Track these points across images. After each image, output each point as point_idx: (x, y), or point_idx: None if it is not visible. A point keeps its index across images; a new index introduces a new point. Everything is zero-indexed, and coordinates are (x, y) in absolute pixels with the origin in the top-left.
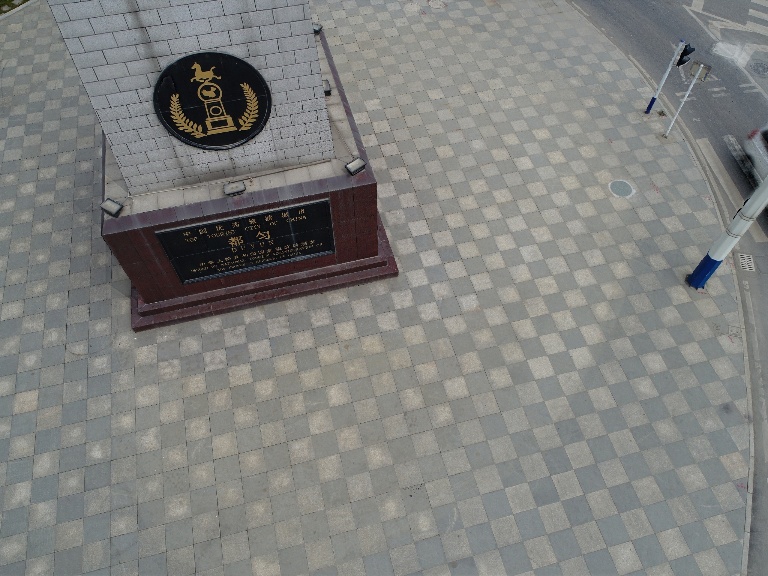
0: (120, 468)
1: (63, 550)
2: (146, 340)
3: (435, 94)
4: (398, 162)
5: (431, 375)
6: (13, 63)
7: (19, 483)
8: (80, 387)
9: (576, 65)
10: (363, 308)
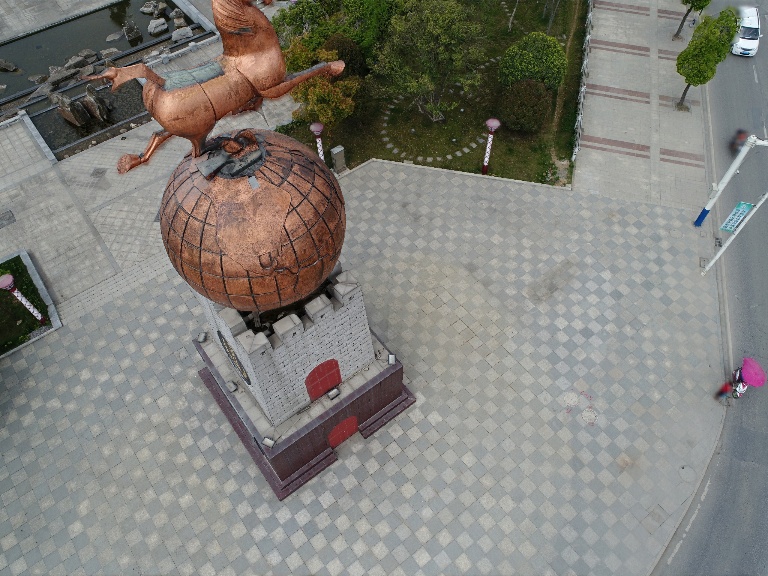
0: (123, 412)
1: (81, 411)
2: (196, 382)
3: (469, 459)
4: (383, 460)
5: (212, 552)
6: (370, 196)
7: (108, 373)
8: (161, 368)
9: (574, 570)
10: (249, 489)
